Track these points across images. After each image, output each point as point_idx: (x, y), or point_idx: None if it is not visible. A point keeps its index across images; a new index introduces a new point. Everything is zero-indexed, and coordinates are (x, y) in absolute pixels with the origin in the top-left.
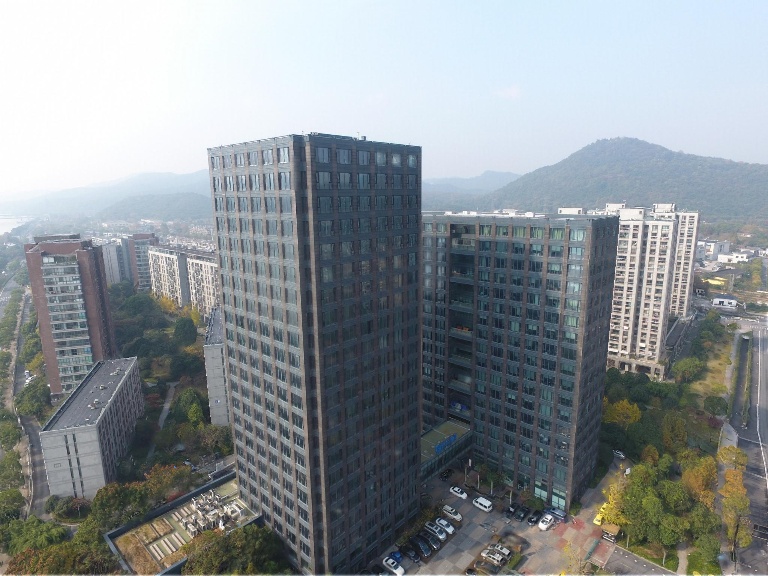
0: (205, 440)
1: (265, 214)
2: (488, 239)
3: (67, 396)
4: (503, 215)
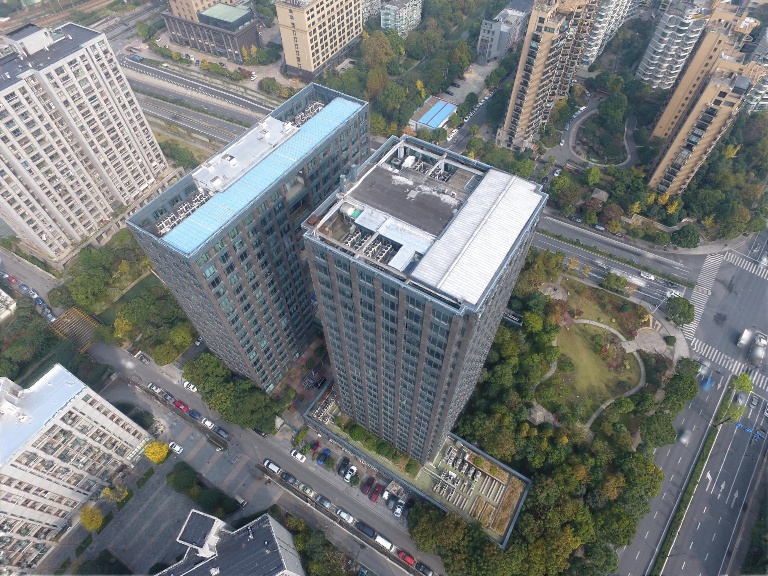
0: (338, 566)
1: None
2: (315, 170)
3: None
4: (277, 141)
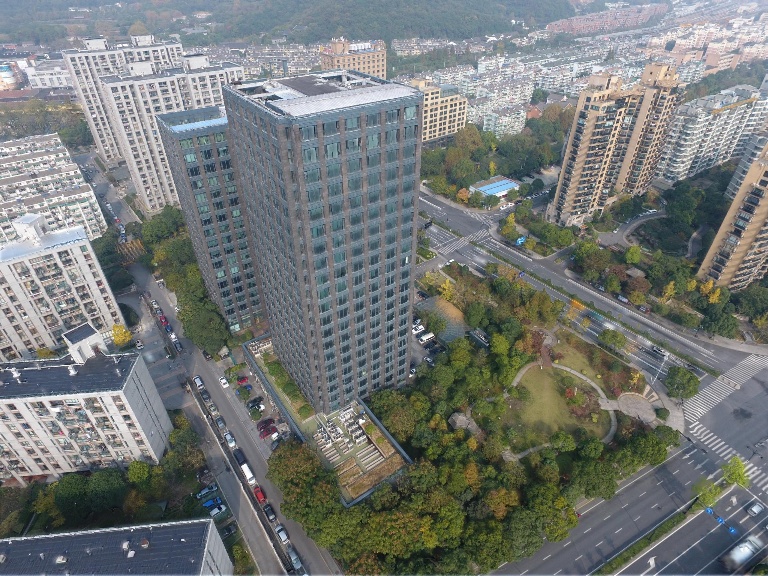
0: (191, 464)
1: (385, 166)
2: None
3: None
4: None
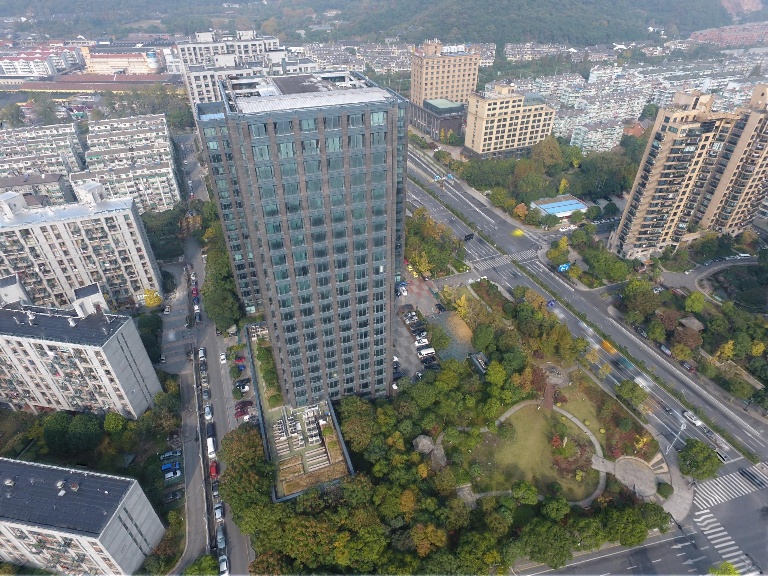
0: (162, 426)
1: (349, 171)
2: None
3: (3, 520)
4: None
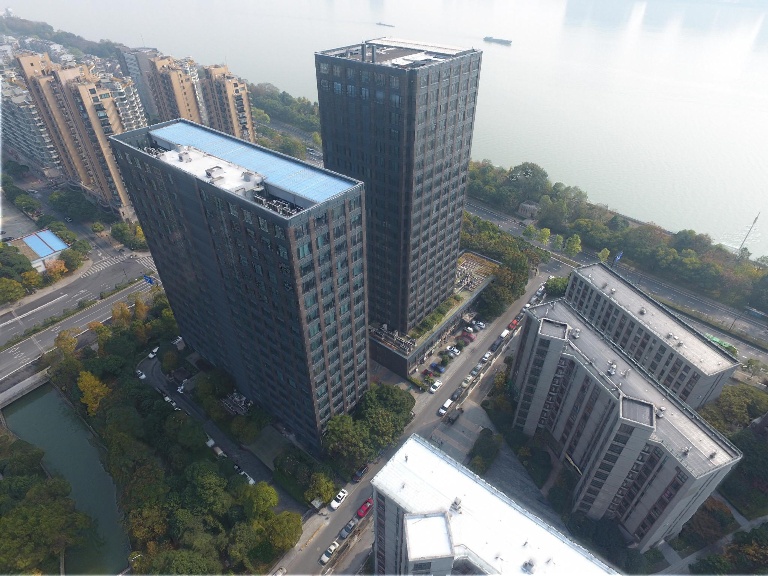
0: None
1: None
2: None
3: None
4: None
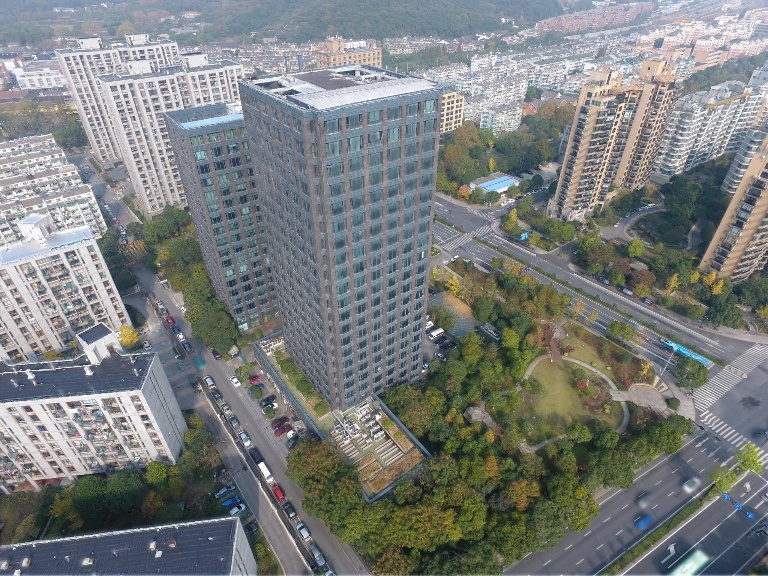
0: (209, 463)
1: None
2: None
3: None
4: None
